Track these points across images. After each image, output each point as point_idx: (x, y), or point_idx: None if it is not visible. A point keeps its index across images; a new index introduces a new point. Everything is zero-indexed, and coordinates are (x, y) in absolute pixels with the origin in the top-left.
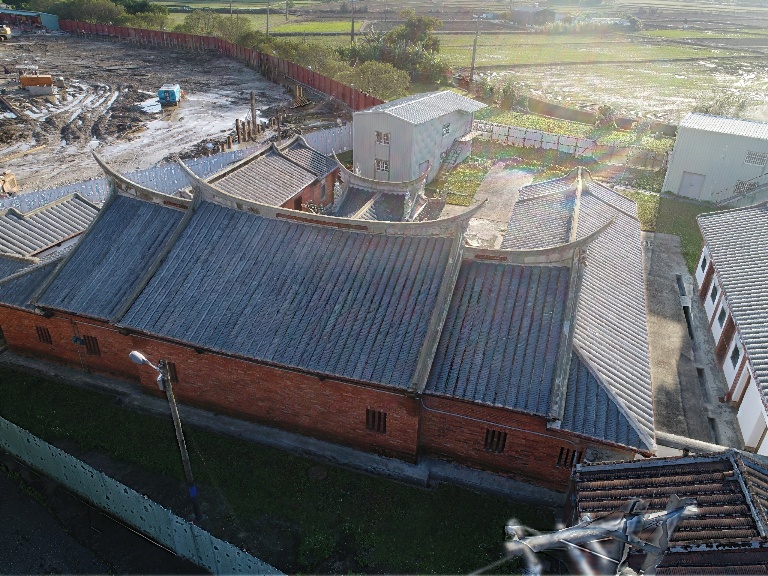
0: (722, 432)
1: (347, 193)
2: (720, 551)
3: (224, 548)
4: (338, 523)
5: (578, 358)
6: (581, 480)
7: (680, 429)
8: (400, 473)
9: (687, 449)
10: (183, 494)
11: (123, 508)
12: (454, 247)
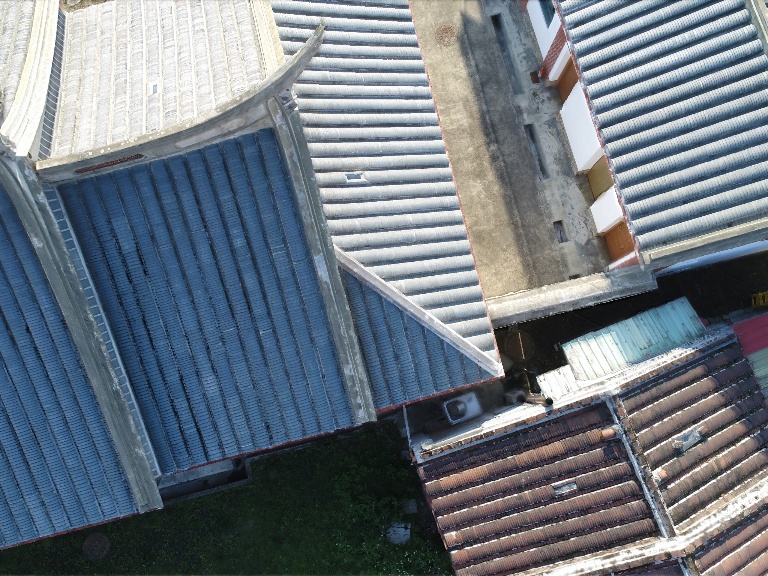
0: (546, 149)
1: None
2: (619, 575)
3: None
4: None
5: (356, 280)
6: (428, 478)
7: (496, 173)
8: (196, 478)
9: (549, 400)
10: None
11: None
12: (18, 207)
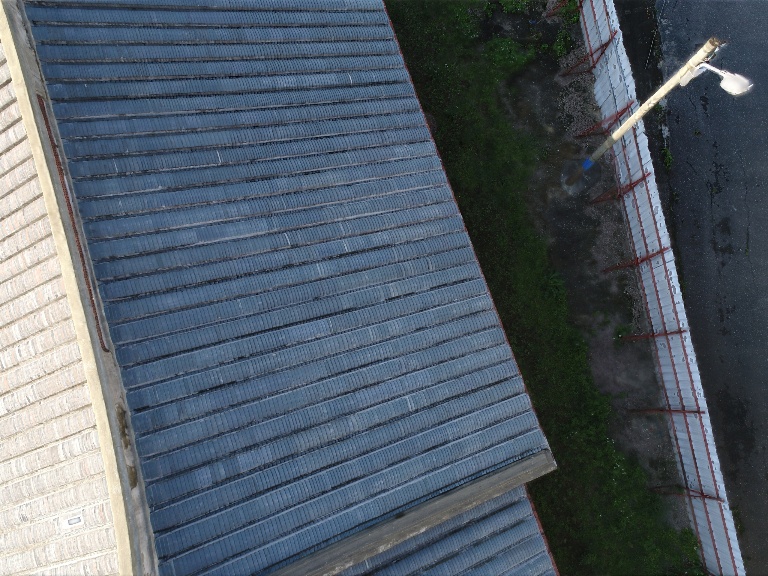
0: None
1: None
2: None
3: (621, 63)
4: (467, 57)
5: None
6: None
7: None
8: None
9: None
10: (559, 228)
11: (641, 237)
12: None
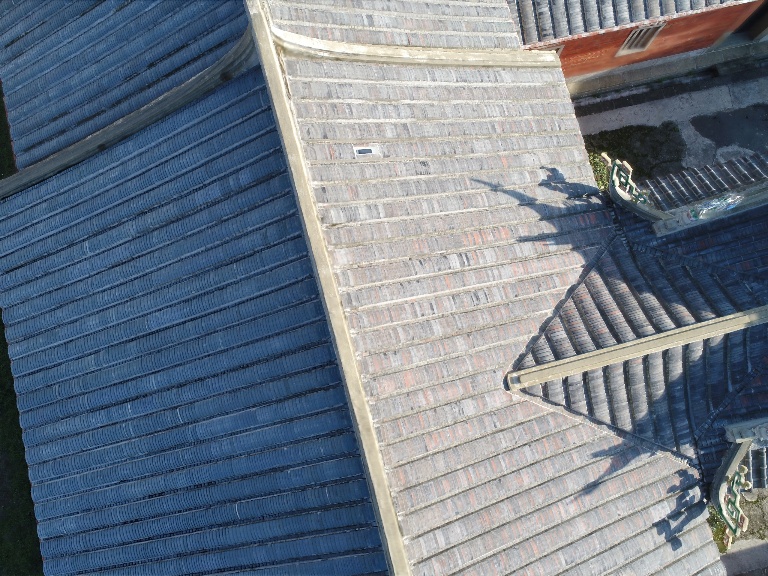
0: None
1: (756, 208)
2: None
3: None
4: None
5: None
6: None
7: None
8: None
9: None
10: None
11: None
12: None
